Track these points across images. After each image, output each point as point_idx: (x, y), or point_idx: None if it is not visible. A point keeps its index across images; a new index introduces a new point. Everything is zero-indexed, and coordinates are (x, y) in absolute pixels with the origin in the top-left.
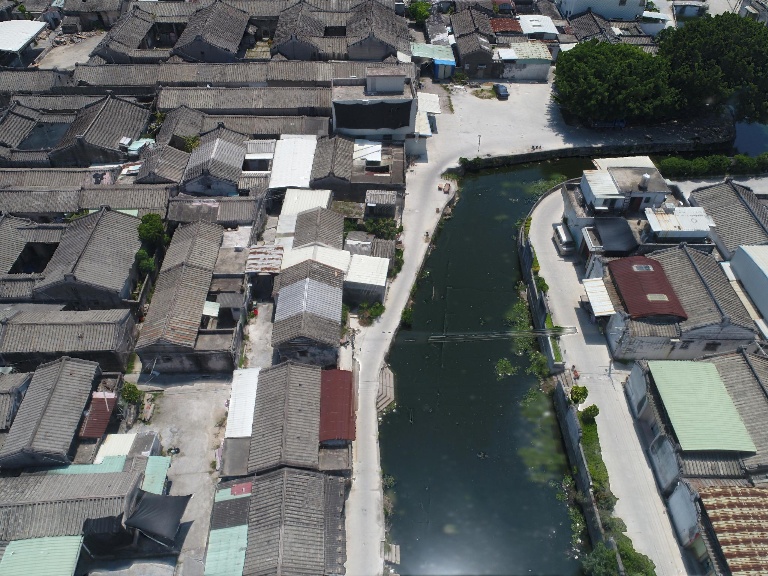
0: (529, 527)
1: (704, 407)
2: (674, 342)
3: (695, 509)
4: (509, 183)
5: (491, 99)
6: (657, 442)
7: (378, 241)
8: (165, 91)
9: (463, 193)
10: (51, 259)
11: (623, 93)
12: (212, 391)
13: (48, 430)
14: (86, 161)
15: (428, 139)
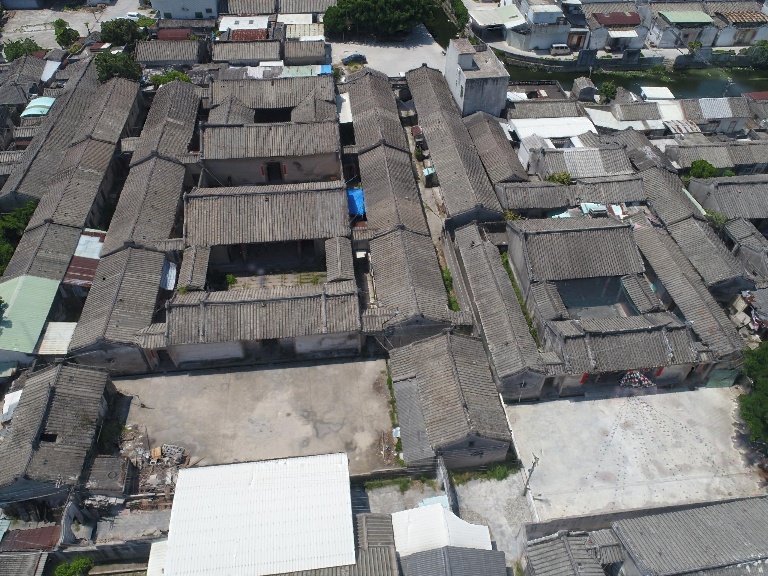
0: None
1: None
2: None
3: (734, 27)
4: None
5: None
6: (698, 37)
7: (624, 92)
8: None
9: None
10: None
11: None
12: None
13: None
14: None
15: None
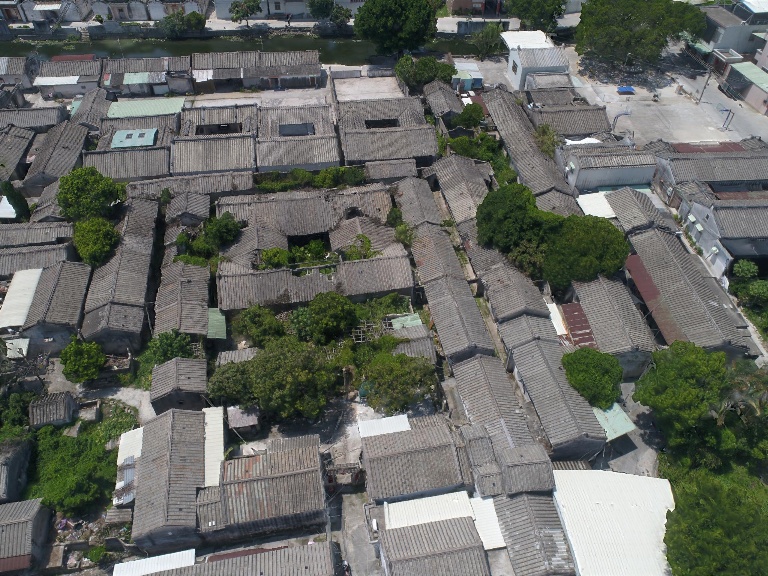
0: (149, 47)
1: None
2: None
3: (158, 2)
4: None
5: None
6: (129, 11)
7: None
8: None
9: None
10: None
11: None
12: None
13: None
14: None
15: None
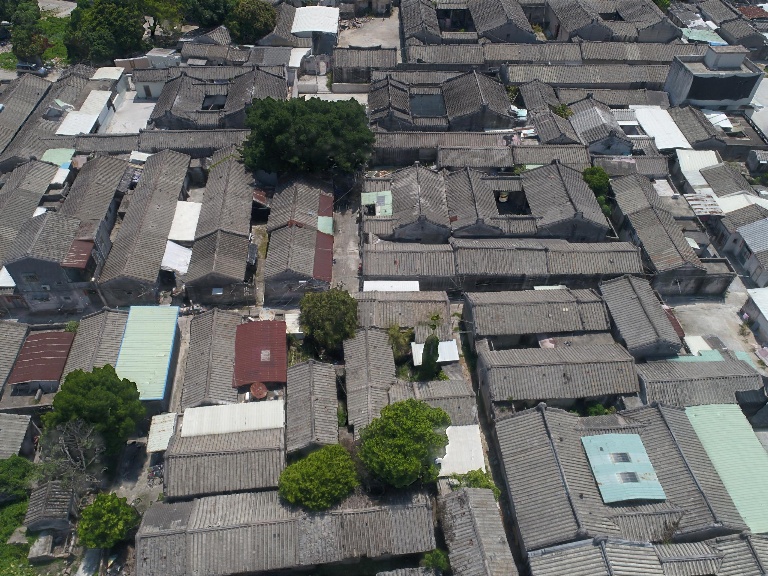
0: None
1: None
2: None
3: None
4: None
5: None
6: None
7: None
8: (512, 67)
9: None
10: (530, 203)
11: None
12: (714, 309)
13: (660, 328)
14: (479, 126)
15: None
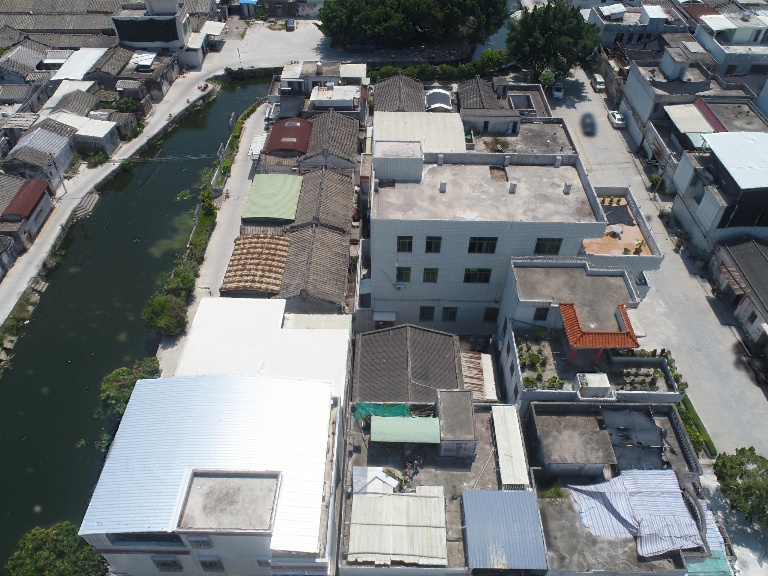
0: (145, 276)
1: (274, 197)
2: (294, 170)
3: None
4: (263, 87)
5: (280, 30)
6: None
7: (116, 113)
8: None
9: (222, 93)
10: None
11: (357, 17)
12: None
13: None
14: None
15: (209, 56)
